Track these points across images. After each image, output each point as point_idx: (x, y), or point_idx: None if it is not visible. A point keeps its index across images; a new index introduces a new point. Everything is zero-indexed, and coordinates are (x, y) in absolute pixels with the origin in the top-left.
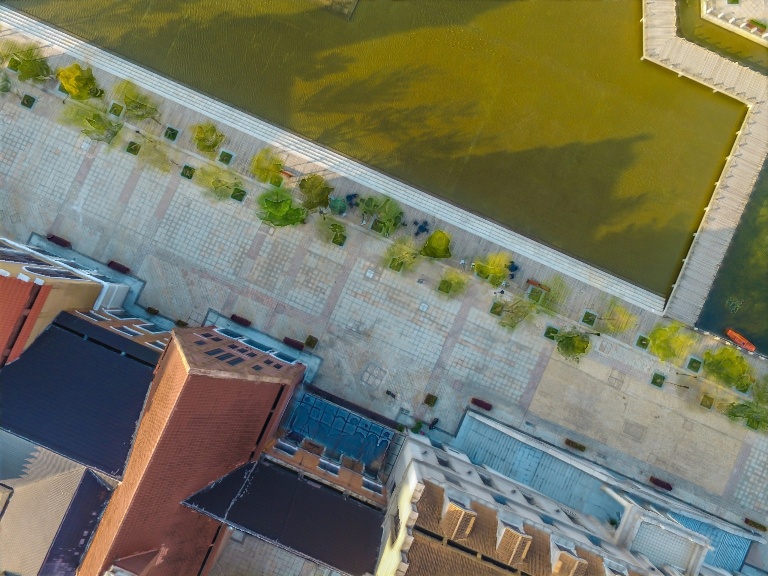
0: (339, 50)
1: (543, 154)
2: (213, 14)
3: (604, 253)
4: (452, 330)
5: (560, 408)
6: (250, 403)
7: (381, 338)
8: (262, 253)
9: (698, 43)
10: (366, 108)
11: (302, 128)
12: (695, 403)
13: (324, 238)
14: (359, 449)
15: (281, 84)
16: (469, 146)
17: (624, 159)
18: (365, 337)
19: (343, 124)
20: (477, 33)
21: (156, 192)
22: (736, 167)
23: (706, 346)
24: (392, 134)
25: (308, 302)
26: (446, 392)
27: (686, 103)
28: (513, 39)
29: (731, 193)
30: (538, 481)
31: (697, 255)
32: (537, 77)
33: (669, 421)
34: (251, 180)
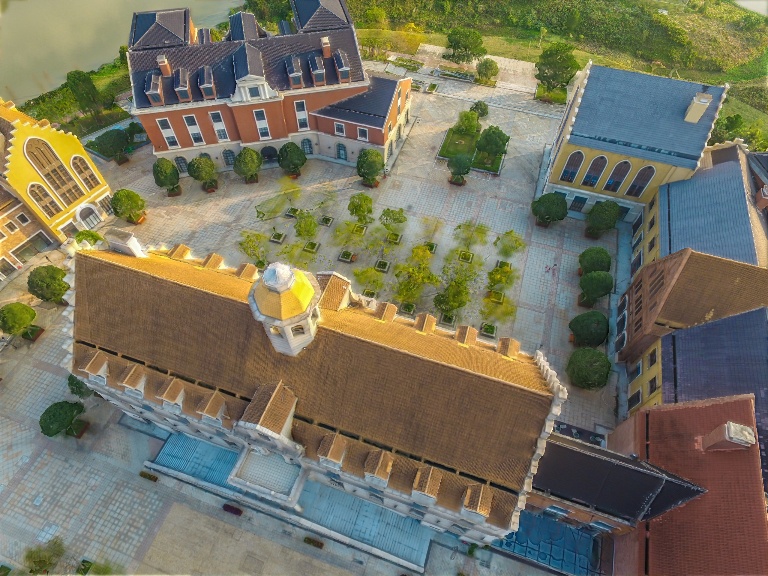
0: None
1: None
2: None
3: None
4: None
5: None
6: None
7: None
8: None
9: None
10: None
11: None
12: None
13: None
14: (521, 520)
15: None
16: None
17: None
18: None
19: None
20: None
21: None
22: None
23: None
24: None
25: None
26: None
27: None
28: None
29: None
30: (356, 506)
31: None
32: None
33: None
34: None
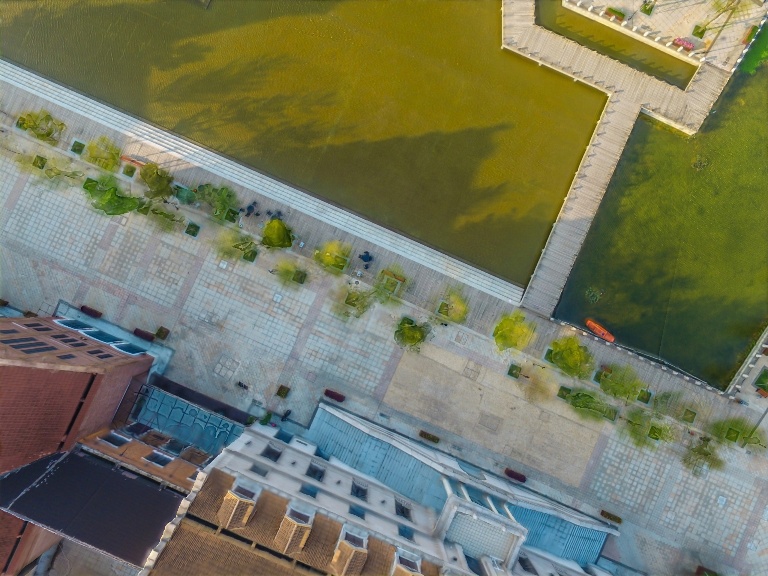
0: (196, 39)
1: (402, 144)
2: (68, 3)
3: (463, 243)
4: (306, 321)
5: (415, 399)
6: (47, 392)
7: (234, 329)
8: (114, 244)
9: (558, 32)
10: (223, 97)
11: (158, 118)
12: (552, 394)
13: (177, 228)
14: (209, 441)
15: (137, 73)
16: (327, 136)
17: (484, 148)
18: (218, 328)
19: (200, 114)
20: (336, 22)
21: (7, 182)
22: (594, 156)
23: (563, 337)
24: (249, 124)
25: (160, 293)
26: (299, 383)
27: (547, 92)
28: (372, 28)
29: (589, 182)
30: (384, 473)
31: (554, 245)
32: (396, 66)
33: (525, 412)
34: (104, 170)
